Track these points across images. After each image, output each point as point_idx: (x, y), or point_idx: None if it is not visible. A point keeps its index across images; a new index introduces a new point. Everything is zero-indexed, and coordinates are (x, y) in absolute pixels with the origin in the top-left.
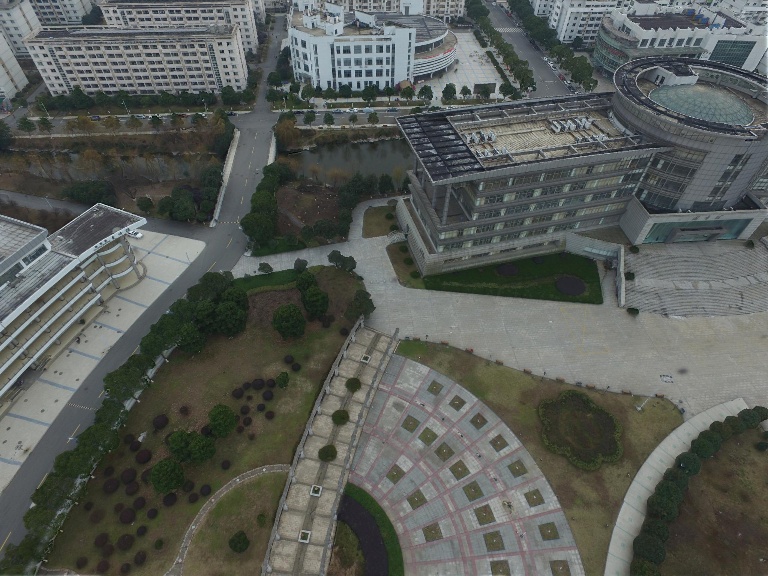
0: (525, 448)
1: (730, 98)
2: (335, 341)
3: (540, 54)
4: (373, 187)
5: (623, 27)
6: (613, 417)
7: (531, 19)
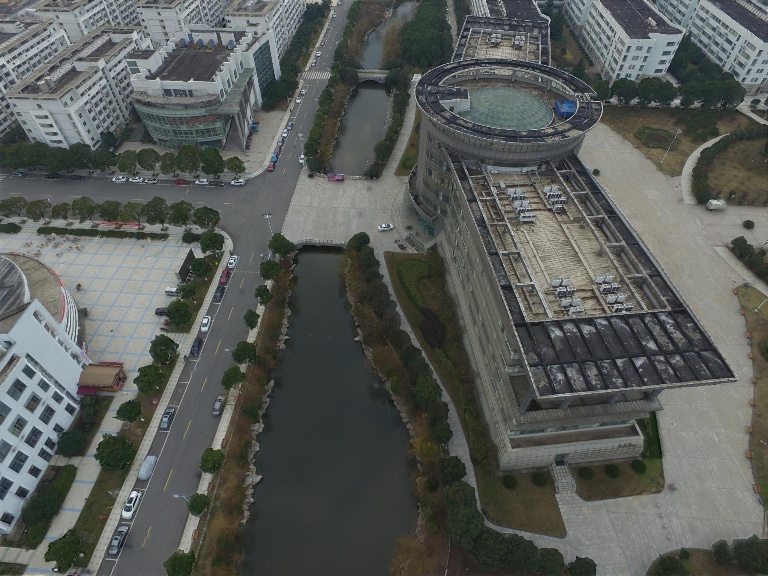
0: None
1: (508, 89)
2: None
3: (96, 180)
4: None
5: (166, 92)
6: None
7: (10, 153)
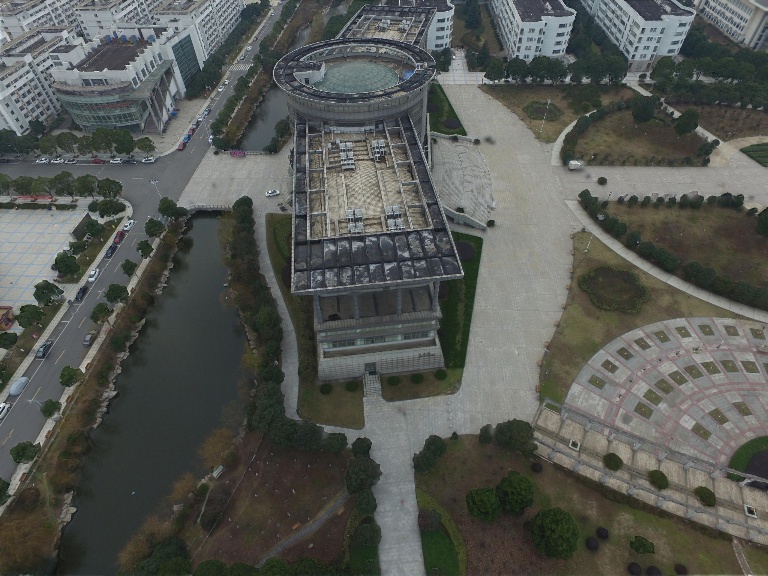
0: (641, 327)
1: (362, 62)
2: (551, 480)
3: (22, 163)
4: (281, 393)
5: (85, 82)
6: (600, 266)
7: None
